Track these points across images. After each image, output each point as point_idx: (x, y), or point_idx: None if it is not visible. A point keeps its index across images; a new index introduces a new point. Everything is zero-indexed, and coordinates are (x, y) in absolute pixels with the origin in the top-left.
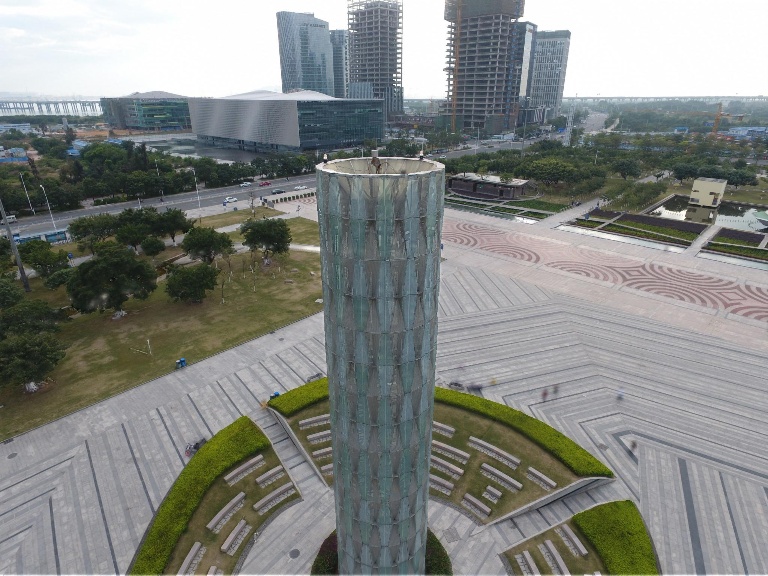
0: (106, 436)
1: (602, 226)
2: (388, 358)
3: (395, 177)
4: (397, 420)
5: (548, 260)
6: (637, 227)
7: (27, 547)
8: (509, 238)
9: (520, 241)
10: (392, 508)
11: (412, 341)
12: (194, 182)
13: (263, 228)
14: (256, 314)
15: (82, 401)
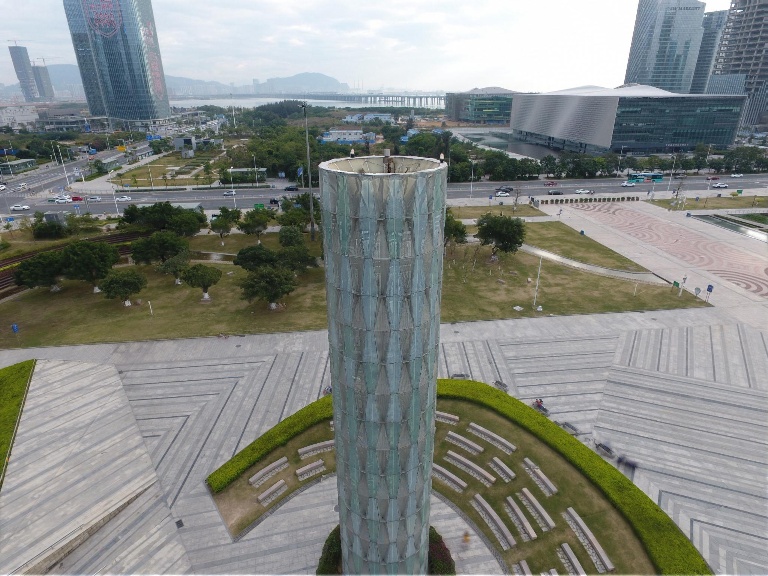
0: (289, 356)
1: None
2: (352, 351)
3: (351, 175)
4: (363, 416)
5: None
6: None
7: (209, 405)
8: None
9: None
10: (362, 501)
11: (374, 343)
12: (471, 173)
13: (496, 224)
14: (451, 303)
15: (292, 326)
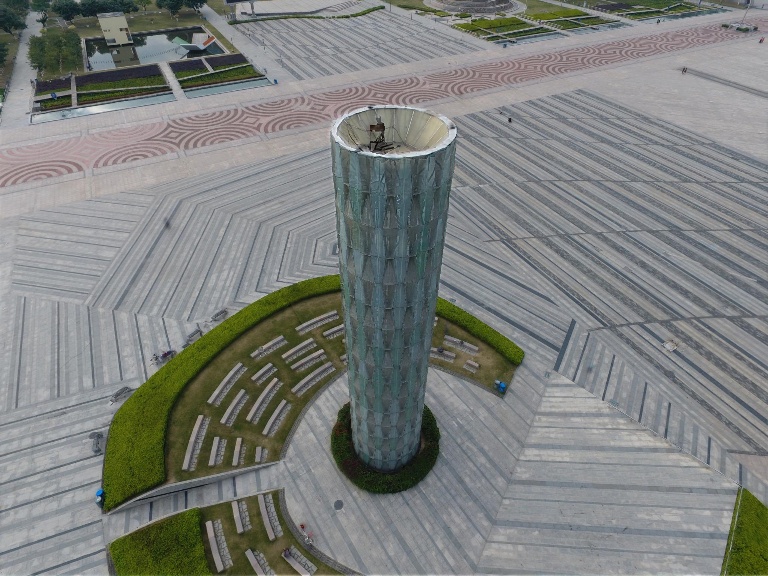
0: None
1: (75, 100)
2: None
3: None
4: None
5: (89, 161)
6: (106, 88)
7: None
8: (2, 159)
9: (22, 156)
10: None
11: None
12: None
13: None
14: None
15: None
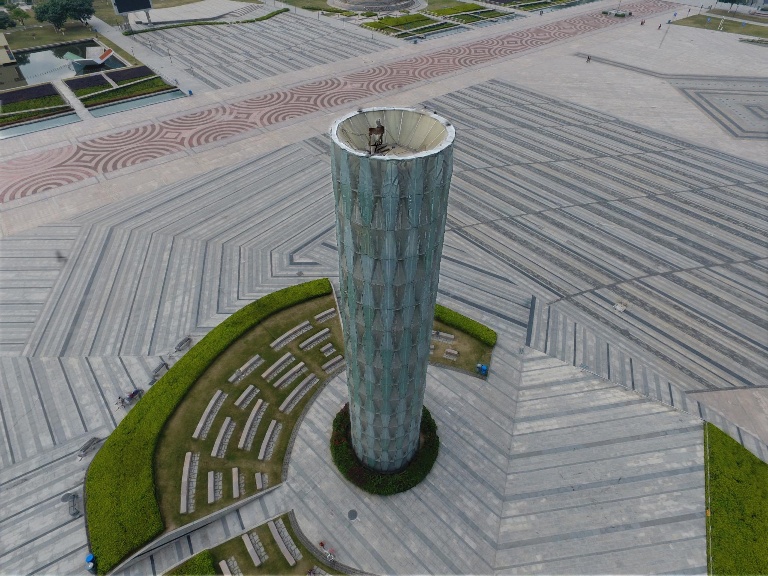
0: None
1: None
2: None
3: None
4: None
5: None
6: None
7: None
8: None
9: None
10: None
11: None
12: None
13: None
14: None
15: None
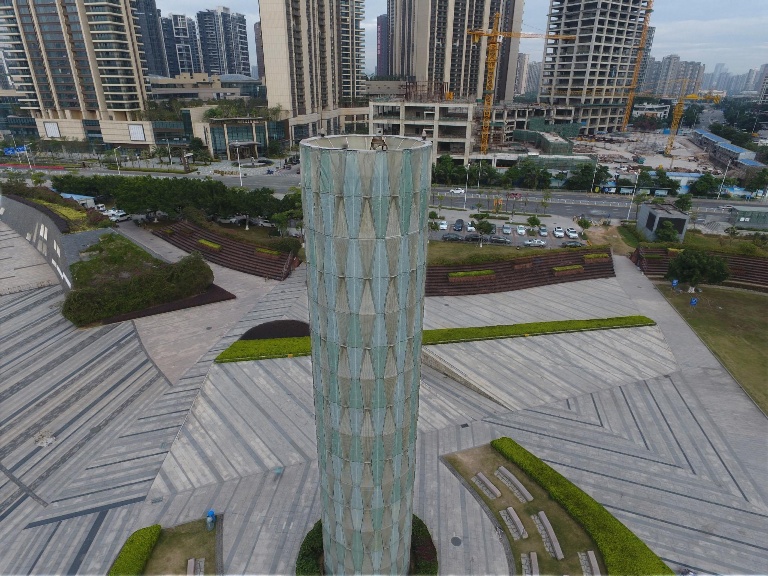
0: None
1: None
2: None
3: None
4: None
5: None
6: None
7: (624, 442)
8: None
9: None
10: None
11: None
12: None
13: None
14: None
15: None
